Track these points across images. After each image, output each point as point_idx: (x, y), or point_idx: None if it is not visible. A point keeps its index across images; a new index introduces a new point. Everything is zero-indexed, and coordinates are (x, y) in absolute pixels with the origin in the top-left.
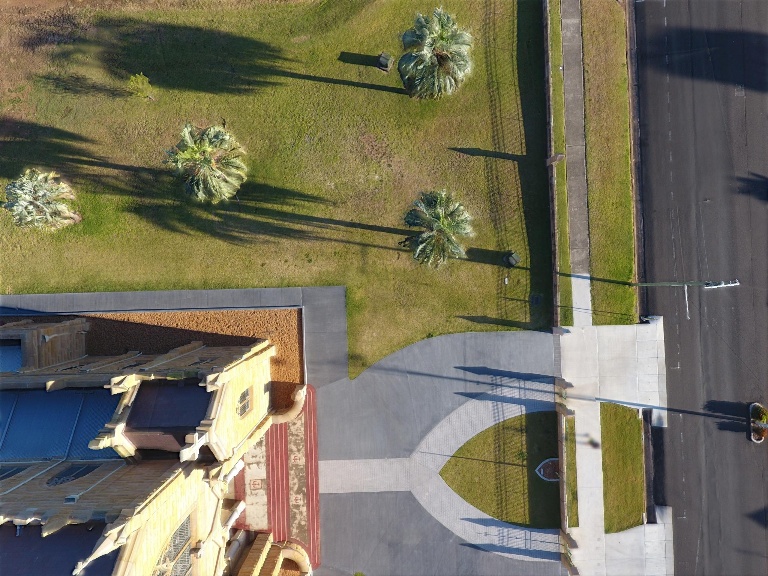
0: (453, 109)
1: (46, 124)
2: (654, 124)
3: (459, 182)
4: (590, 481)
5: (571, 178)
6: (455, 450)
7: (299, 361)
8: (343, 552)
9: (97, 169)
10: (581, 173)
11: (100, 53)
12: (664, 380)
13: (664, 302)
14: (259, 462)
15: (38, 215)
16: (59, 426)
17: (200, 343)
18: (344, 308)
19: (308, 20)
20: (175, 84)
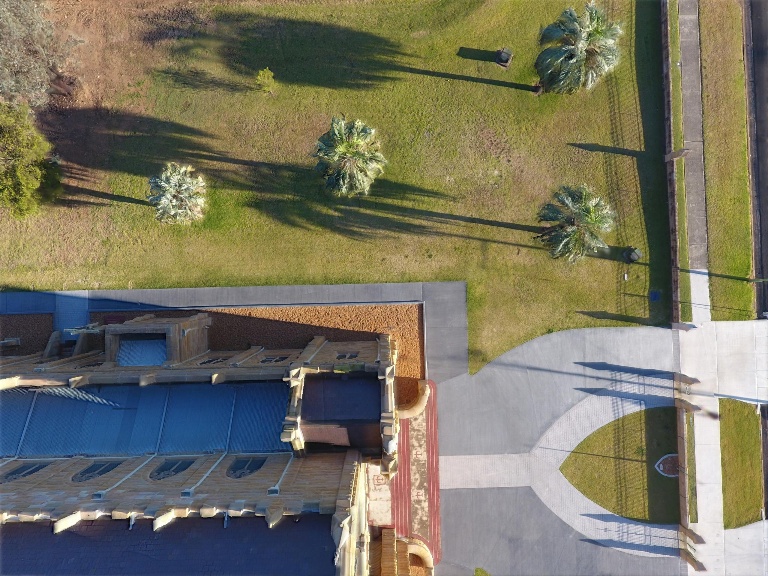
0: (572, 105)
1: (165, 119)
2: None
3: (578, 178)
4: (709, 477)
5: (689, 174)
6: (575, 446)
7: (420, 356)
8: (463, 548)
9: (217, 164)
10: (699, 169)
11: (220, 48)
12: None
13: None
14: None
15: (180, 209)
16: (215, 420)
17: (323, 338)
18: (464, 303)
19: (427, 15)
20: (294, 79)
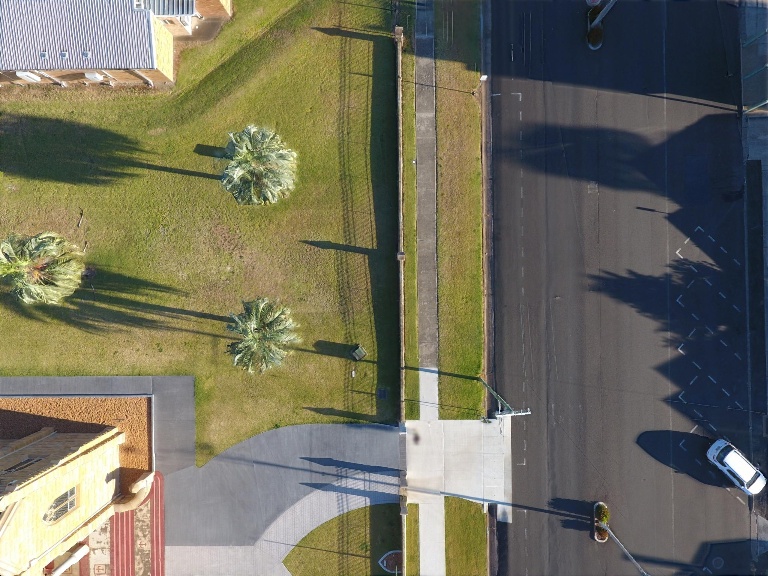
0: (305, 202)
1: None
2: (507, 219)
3: (309, 275)
4: (433, 574)
5: (421, 272)
6: (299, 540)
7: (148, 448)
8: None
9: None
10: (432, 267)
11: None
12: (510, 476)
13: (512, 398)
14: (104, 548)
15: None
16: None
17: (50, 430)
18: (193, 397)
19: (165, 112)
20: (35, 174)
